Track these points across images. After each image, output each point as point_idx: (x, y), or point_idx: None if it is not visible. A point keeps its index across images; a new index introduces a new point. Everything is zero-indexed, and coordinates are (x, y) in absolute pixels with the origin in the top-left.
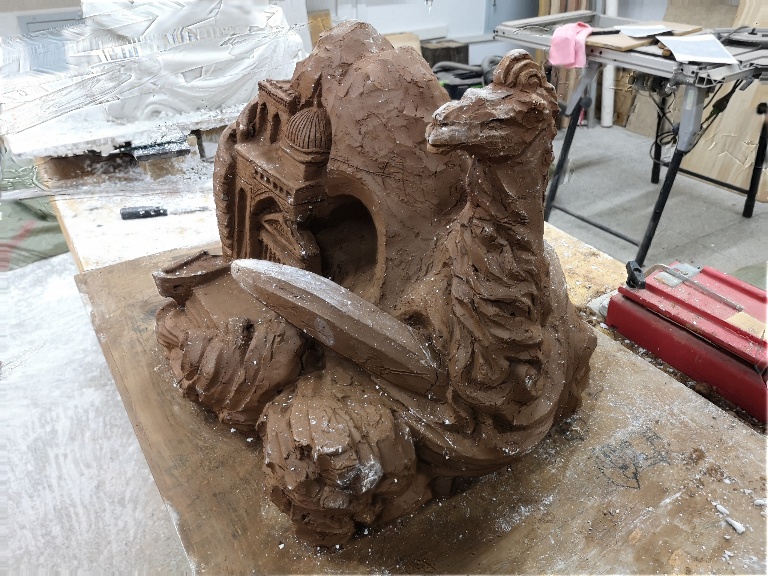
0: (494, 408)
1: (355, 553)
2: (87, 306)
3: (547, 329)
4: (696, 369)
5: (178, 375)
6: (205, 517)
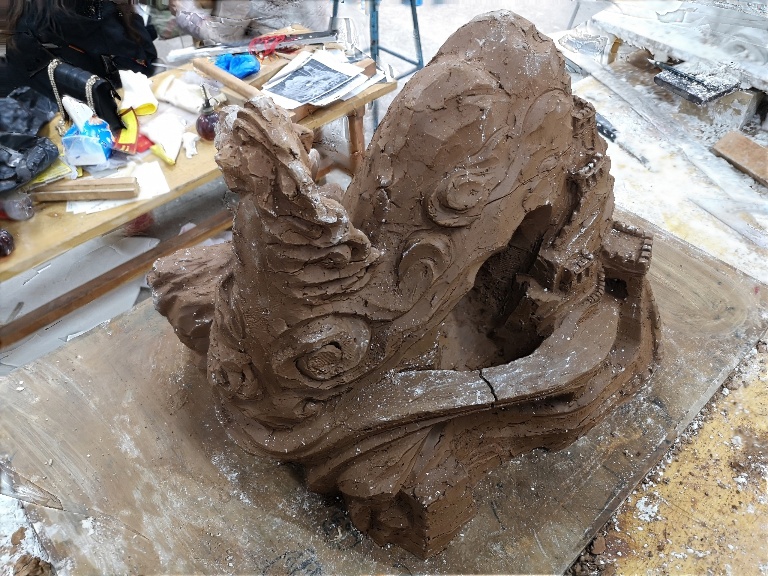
0: None
1: None
2: None
3: (331, 415)
4: None
5: None
6: None
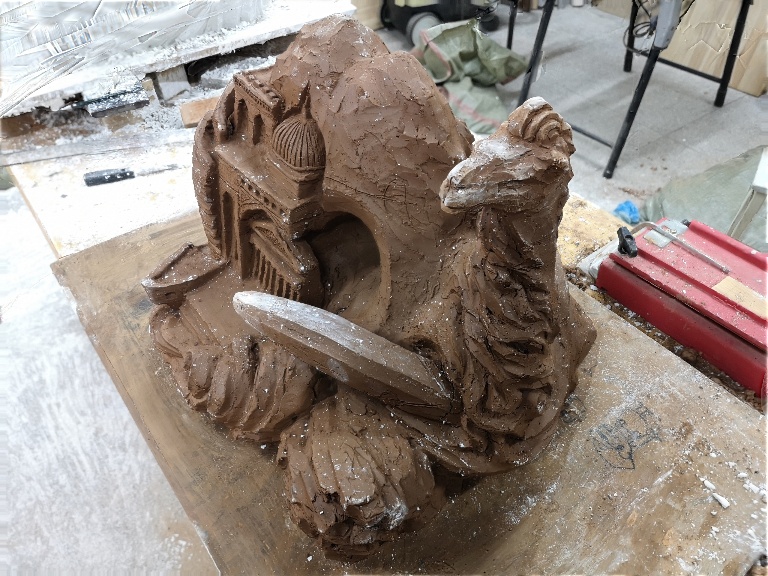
0: (507, 432)
1: (379, 559)
2: (71, 302)
3: None
4: (684, 335)
5: (184, 389)
6: (233, 534)
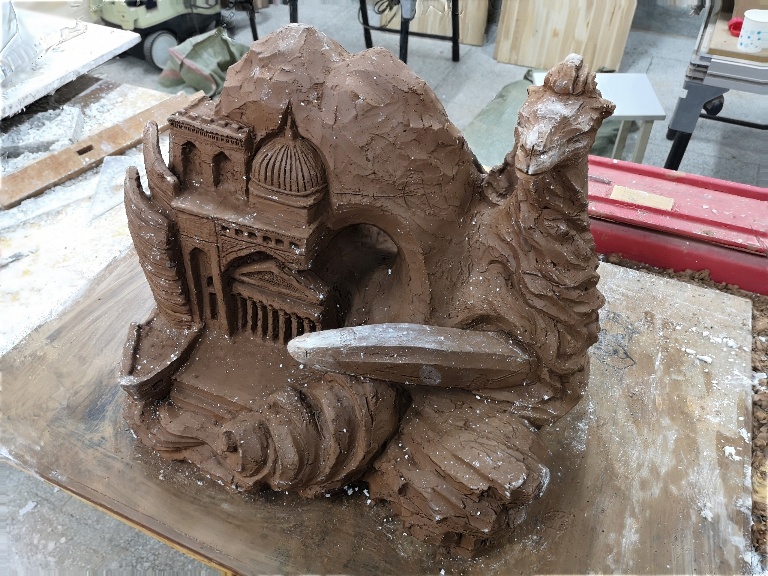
0: (579, 368)
1: None
2: None
3: None
4: (603, 245)
5: (224, 476)
6: None
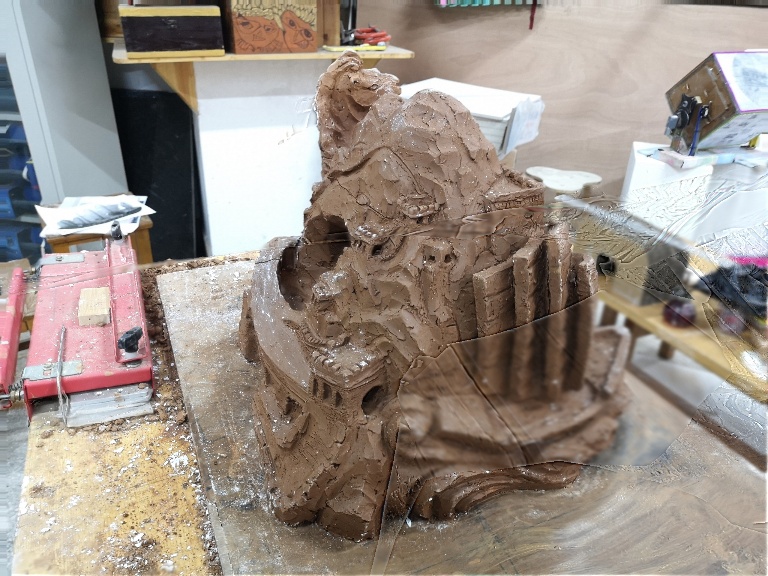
0: None
1: None
2: None
3: None
4: None
5: None
6: None
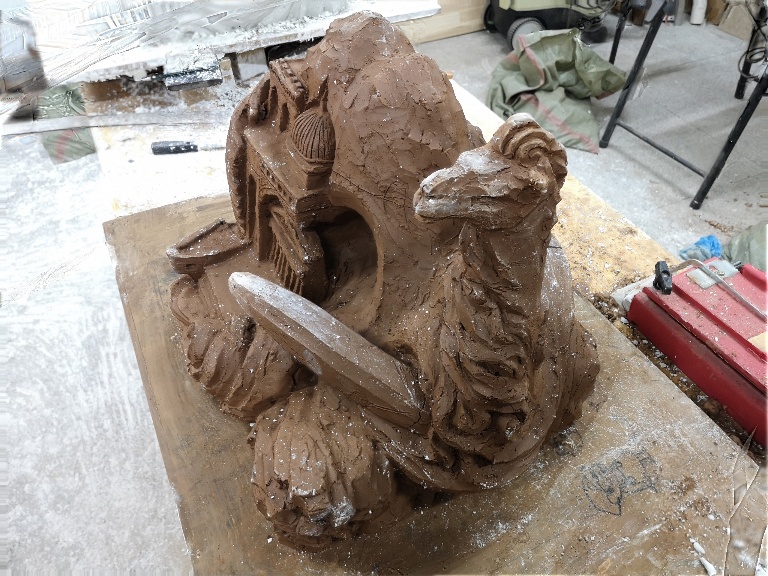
0: (473, 452)
1: (335, 555)
2: (113, 260)
3: (545, 360)
4: (709, 385)
5: None
6: (204, 503)
